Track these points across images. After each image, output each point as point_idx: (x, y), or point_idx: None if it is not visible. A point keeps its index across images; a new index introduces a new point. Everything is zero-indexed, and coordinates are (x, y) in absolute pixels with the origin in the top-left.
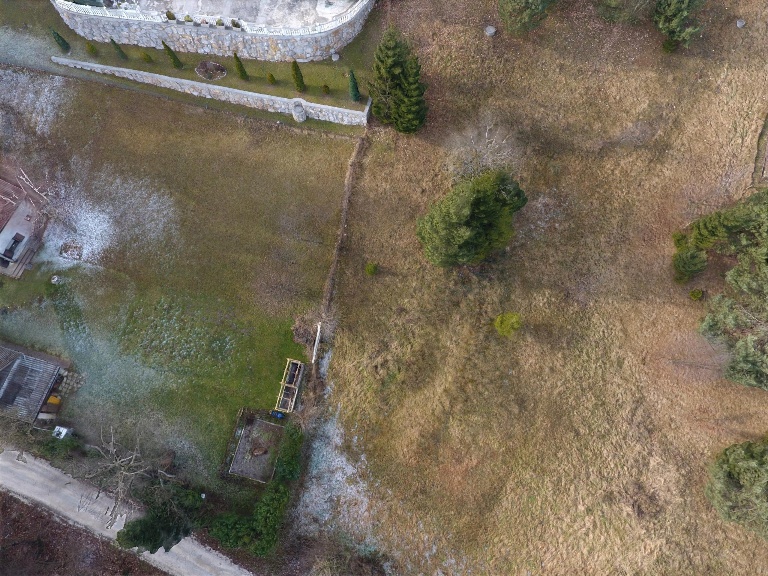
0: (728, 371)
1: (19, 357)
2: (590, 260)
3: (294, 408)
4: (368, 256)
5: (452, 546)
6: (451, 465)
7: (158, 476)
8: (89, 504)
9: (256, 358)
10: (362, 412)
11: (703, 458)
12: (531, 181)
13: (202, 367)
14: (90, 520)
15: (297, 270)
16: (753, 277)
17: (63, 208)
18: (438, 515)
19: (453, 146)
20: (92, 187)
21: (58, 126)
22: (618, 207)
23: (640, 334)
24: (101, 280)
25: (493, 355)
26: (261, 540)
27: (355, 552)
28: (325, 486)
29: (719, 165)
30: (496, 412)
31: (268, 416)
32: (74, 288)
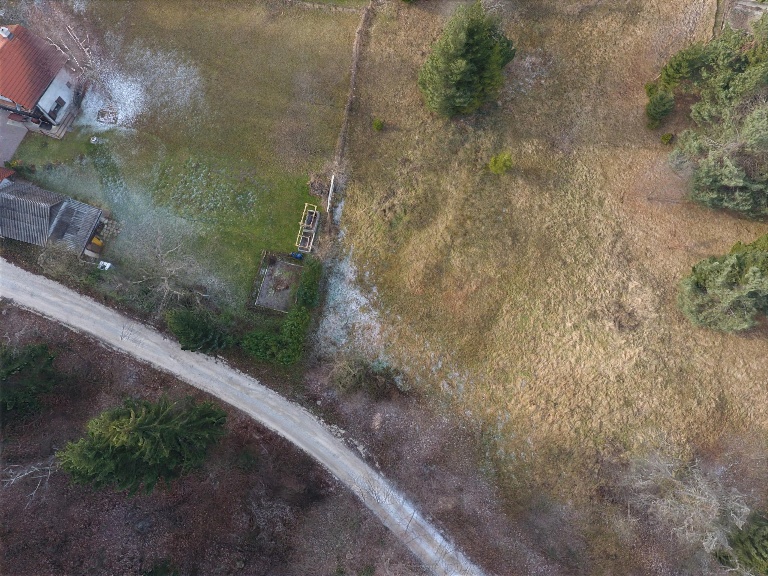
0: (694, 192)
1: (66, 200)
2: (573, 113)
3: (312, 250)
4: (375, 114)
5: (455, 361)
6: (453, 292)
7: (192, 306)
8: (130, 334)
9: (276, 210)
10: (373, 251)
11: (675, 281)
12: (519, 42)
13: (228, 217)
14: (132, 347)
15: (311, 131)
16: (713, 107)
17: (99, 78)
18: (442, 335)
19: (449, 13)
20: (125, 59)
21: (93, 5)
22: (596, 64)
23: (618, 177)
24: (135, 142)
25: (488, 195)
26: (287, 349)
27: (370, 368)
28: (341, 314)
29: (684, 22)
30: (492, 244)
31: (288, 258)
32: (111, 148)
